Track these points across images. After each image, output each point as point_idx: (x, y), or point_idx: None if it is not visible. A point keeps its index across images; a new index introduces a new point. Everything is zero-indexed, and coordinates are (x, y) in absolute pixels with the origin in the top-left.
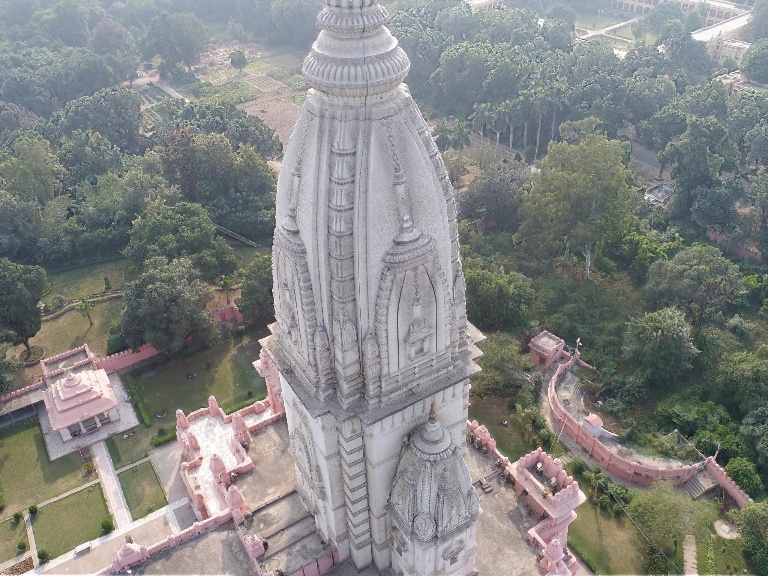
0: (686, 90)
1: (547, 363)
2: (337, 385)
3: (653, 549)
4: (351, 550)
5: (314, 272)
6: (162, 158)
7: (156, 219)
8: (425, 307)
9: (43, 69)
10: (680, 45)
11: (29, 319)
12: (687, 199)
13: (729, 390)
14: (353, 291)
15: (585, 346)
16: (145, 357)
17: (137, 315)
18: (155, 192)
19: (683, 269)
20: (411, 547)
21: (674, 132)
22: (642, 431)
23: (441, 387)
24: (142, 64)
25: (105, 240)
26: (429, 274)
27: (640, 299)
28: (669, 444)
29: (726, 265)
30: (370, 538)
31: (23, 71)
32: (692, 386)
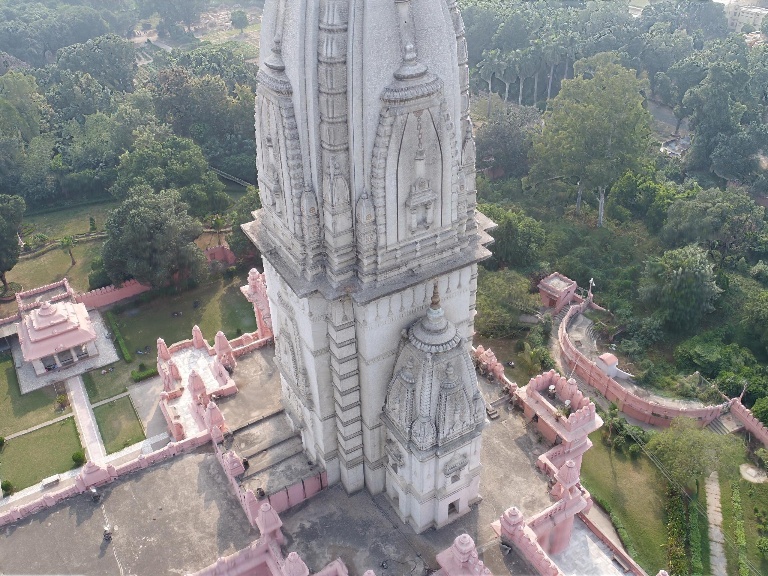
0: (704, 45)
1: (557, 306)
2: (327, 262)
3: (673, 491)
4: (341, 471)
5: (301, 115)
6: (154, 98)
7: (144, 151)
8: (429, 165)
9: (37, 22)
10: (697, 6)
11: (5, 251)
12: (706, 149)
13: (754, 333)
14: (346, 137)
15: (598, 290)
16: (129, 295)
17: (119, 245)
18: (145, 129)
19: (705, 206)
20: (408, 460)
21: (693, 83)
22: (660, 374)
23: (445, 269)
24: (140, 24)
25: (92, 181)
26: (435, 122)
27: (657, 245)
28: (690, 385)
29: (751, 204)
30: (362, 456)
31: (16, 24)
32: (714, 329)
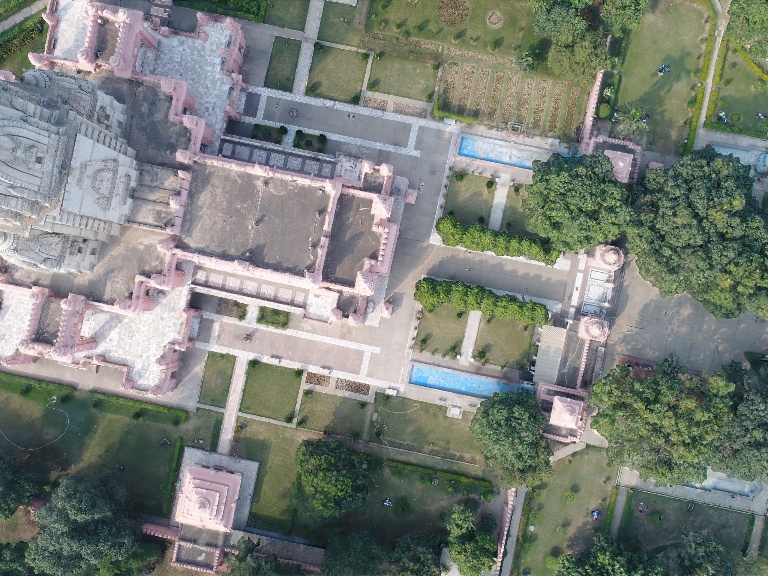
0: None
1: None
2: None
3: None
4: None
5: None
6: None
7: None
8: None
9: None
10: None
11: None
12: None
13: None
14: None
15: None
16: None
17: None
18: None
19: None
20: None
21: None
22: None
23: None
24: None
25: None
26: None
27: None
28: None
29: None
30: None
31: None
32: None
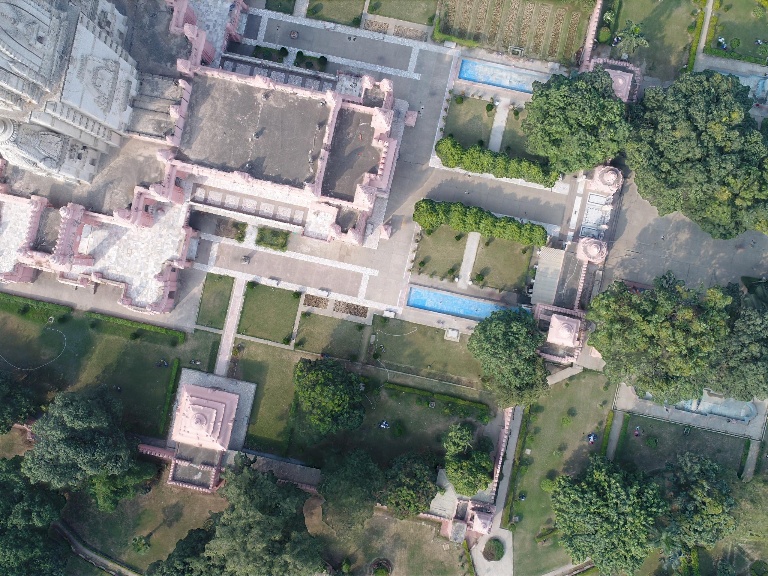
0: None
1: None
2: None
3: None
4: None
5: None
6: None
7: (5, 554)
8: None
9: None
10: None
11: None
12: None
13: None
14: None
15: None
16: None
17: None
18: None
19: None
20: None
21: None
22: None
23: None
24: None
25: None
26: None
27: None
28: None
29: None
30: None
31: None
32: None
